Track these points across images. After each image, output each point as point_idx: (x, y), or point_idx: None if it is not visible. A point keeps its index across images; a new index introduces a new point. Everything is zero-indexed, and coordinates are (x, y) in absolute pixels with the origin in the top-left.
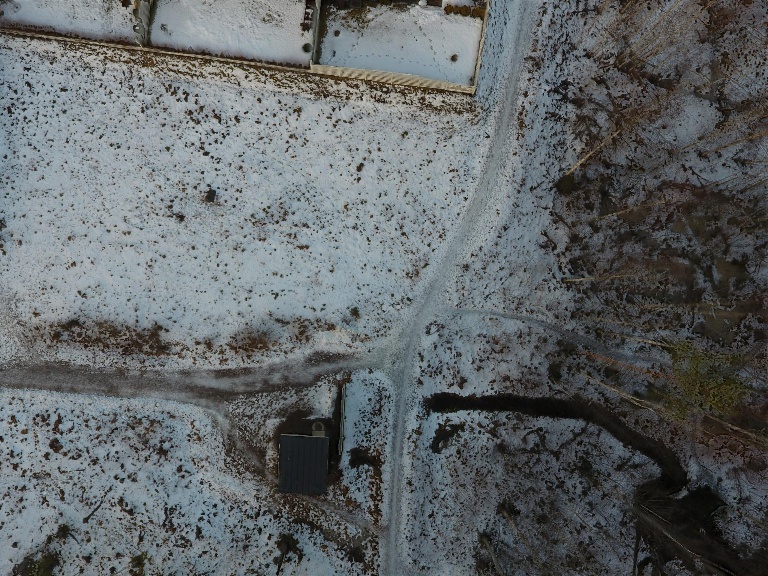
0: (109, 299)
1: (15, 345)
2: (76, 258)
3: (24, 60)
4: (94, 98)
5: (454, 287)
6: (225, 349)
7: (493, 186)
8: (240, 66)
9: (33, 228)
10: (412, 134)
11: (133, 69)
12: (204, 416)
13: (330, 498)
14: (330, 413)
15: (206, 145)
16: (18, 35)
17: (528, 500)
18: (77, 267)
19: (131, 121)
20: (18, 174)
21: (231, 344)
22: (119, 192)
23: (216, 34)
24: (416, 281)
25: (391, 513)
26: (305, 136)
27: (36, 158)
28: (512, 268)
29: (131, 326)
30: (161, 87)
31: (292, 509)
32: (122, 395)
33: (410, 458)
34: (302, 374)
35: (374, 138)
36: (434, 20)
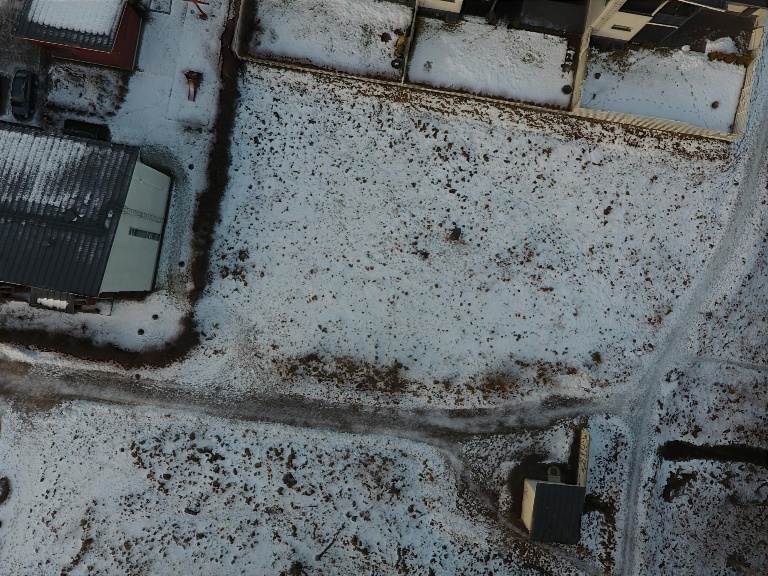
0: (350, 334)
1: (251, 377)
2: (318, 292)
3: (274, 90)
4: (342, 131)
5: (697, 335)
6: (462, 389)
7: (740, 234)
8: (496, 105)
9: (276, 260)
10: (661, 179)
11: (383, 103)
12: (437, 456)
13: (562, 544)
14: (566, 458)
15: (453, 182)
16: (274, 66)
17: (759, 553)
18: (318, 301)
19: (378, 155)
20: (262, 205)
21: (469, 384)
22: (363, 227)
23: (476, 72)
24: (658, 327)
25: (624, 562)
26: (553, 177)
27: (281, 189)
28: (751, 317)
29: (370, 362)
30: (410, 122)
31: (523, 554)
32: (355, 431)
33: (645, 507)
34: (538, 417)
35: (622, 181)
36: (697, 66)
